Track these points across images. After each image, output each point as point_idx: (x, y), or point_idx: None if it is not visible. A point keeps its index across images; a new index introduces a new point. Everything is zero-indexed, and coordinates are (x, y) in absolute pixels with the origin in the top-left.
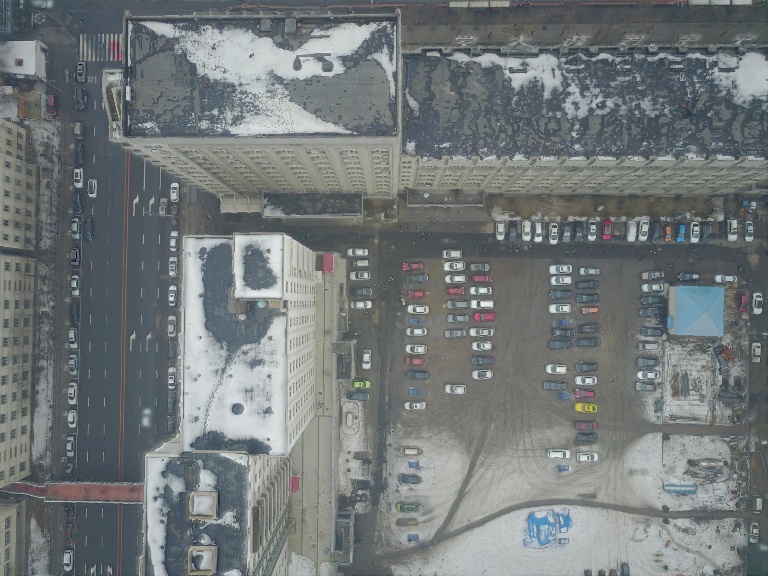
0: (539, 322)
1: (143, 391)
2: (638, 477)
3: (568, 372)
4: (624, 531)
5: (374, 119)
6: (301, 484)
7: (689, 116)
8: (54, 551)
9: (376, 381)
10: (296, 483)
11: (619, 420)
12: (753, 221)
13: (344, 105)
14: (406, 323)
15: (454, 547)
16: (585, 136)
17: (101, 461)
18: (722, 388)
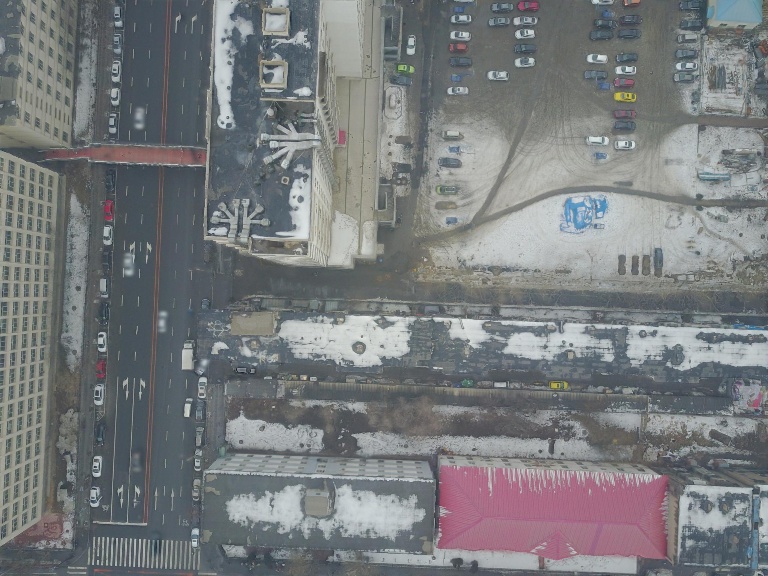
0: (581, 14)
1: (187, 73)
2: (673, 166)
3: (608, 63)
4: (658, 218)
5: None
6: (346, 144)
7: None
8: (93, 227)
9: (419, 67)
10: (343, 137)
11: (657, 111)
12: None
13: None
14: (451, 12)
15: (492, 231)
16: None
17: (143, 140)
18: (758, 80)
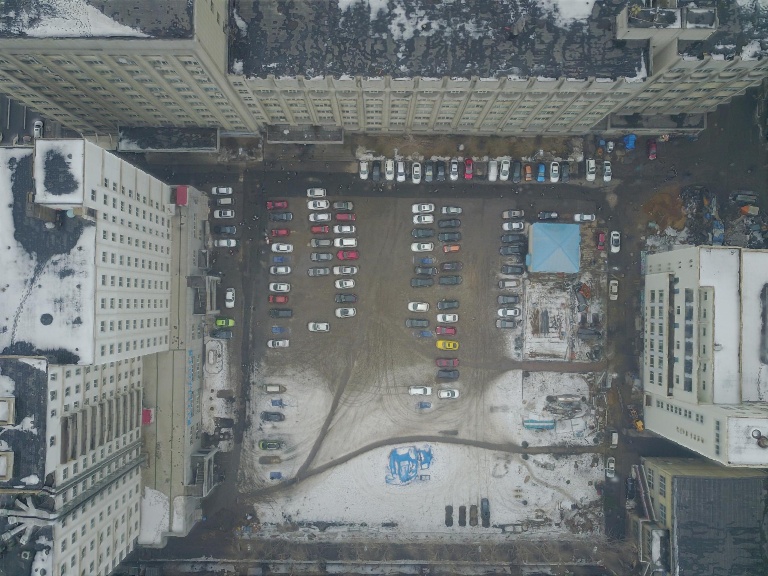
0: (402, 261)
1: None
2: (499, 413)
3: (430, 310)
4: (485, 467)
5: (172, 23)
6: (155, 418)
7: (513, 38)
8: None
9: (240, 319)
10: (147, 416)
11: (480, 357)
12: (612, 161)
13: (142, 9)
14: (270, 262)
15: (316, 485)
16: (411, 57)
17: None
18: (580, 325)
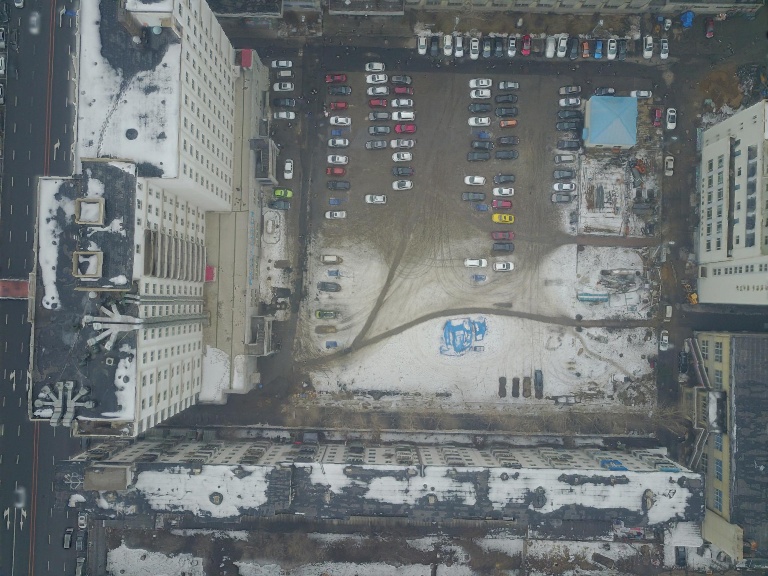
0: (459, 135)
1: None
2: (553, 287)
3: (486, 184)
4: (538, 339)
5: None
6: (217, 278)
7: None
8: None
9: (298, 191)
10: (211, 273)
11: (535, 231)
12: (669, 40)
13: None
14: (328, 135)
15: (372, 354)
16: None
17: (23, 268)
18: (635, 200)
